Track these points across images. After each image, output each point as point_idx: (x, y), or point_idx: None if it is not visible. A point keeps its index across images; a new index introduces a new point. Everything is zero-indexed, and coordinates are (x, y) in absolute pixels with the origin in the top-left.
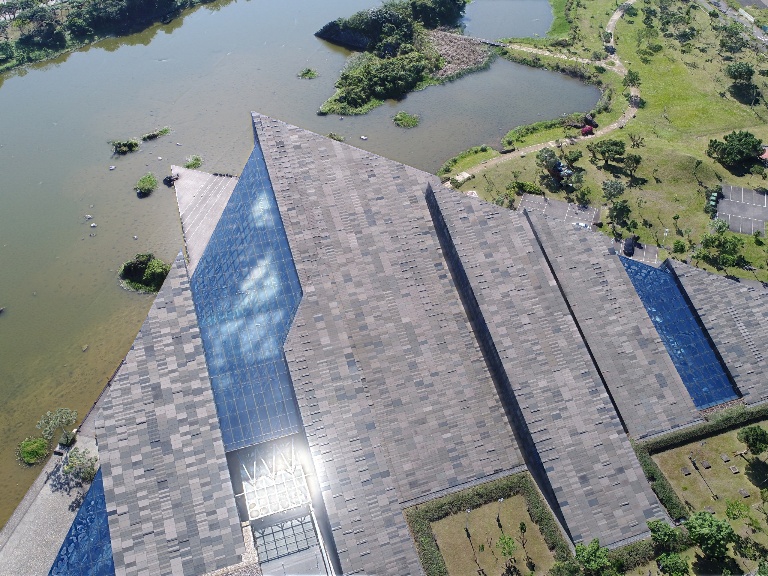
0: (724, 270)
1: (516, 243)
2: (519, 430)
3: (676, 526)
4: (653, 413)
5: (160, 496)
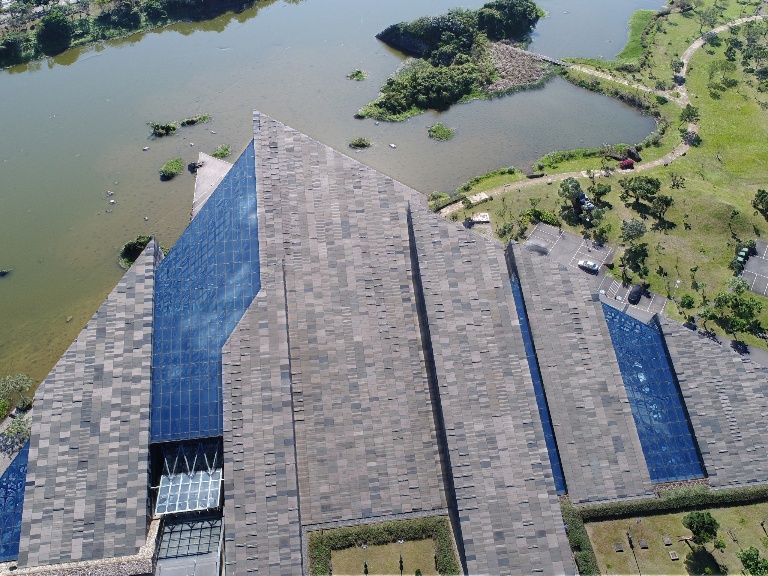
0: (734, 334)
1: (486, 275)
2: (448, 471)
3: None
4: (600, 478)
5: (78, 475)
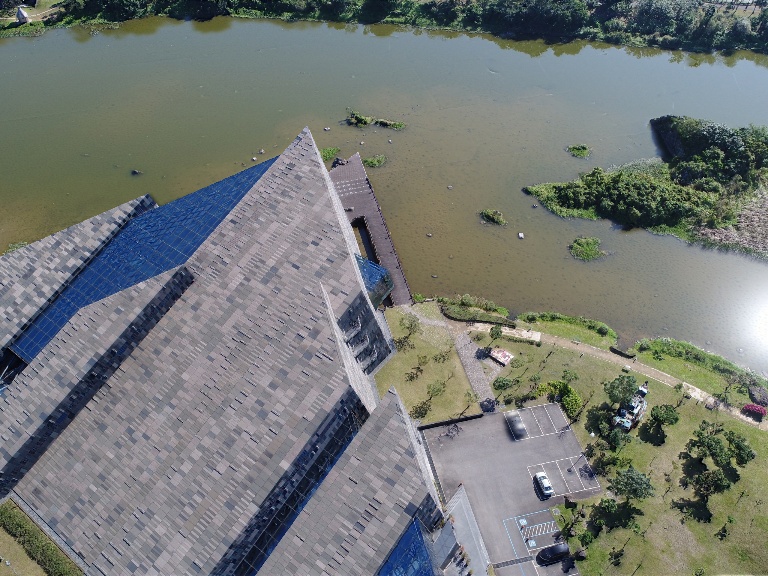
0: None
1: (308, 399)
2: None
3: None
4: None
5: None
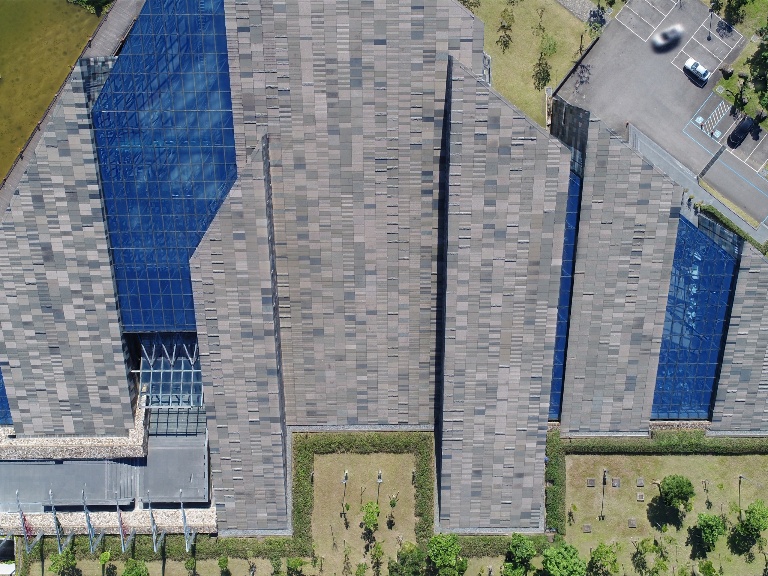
0: None
1: (536, 193)
2: (440, 396)
3: (545, 532)
4: (599, 412)
5: (52, 360)
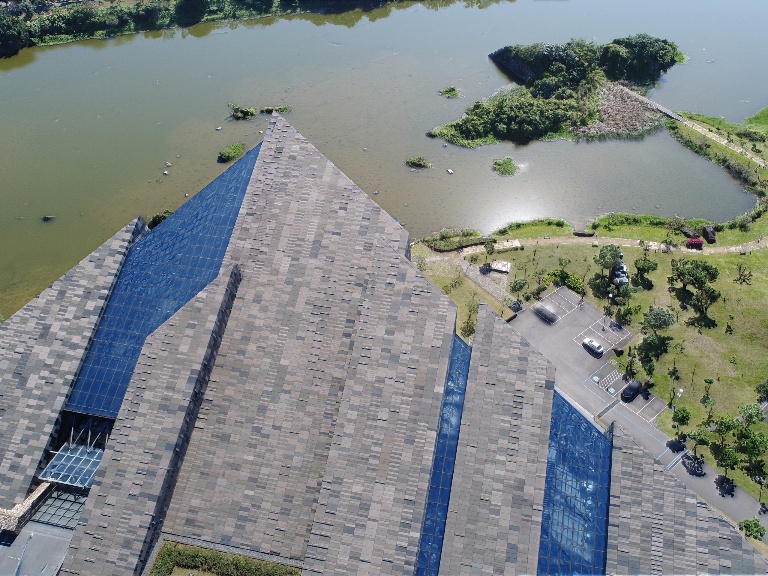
0: (725, 468)
1: (427, 331)
2: None
3: None
4: None
5: None
